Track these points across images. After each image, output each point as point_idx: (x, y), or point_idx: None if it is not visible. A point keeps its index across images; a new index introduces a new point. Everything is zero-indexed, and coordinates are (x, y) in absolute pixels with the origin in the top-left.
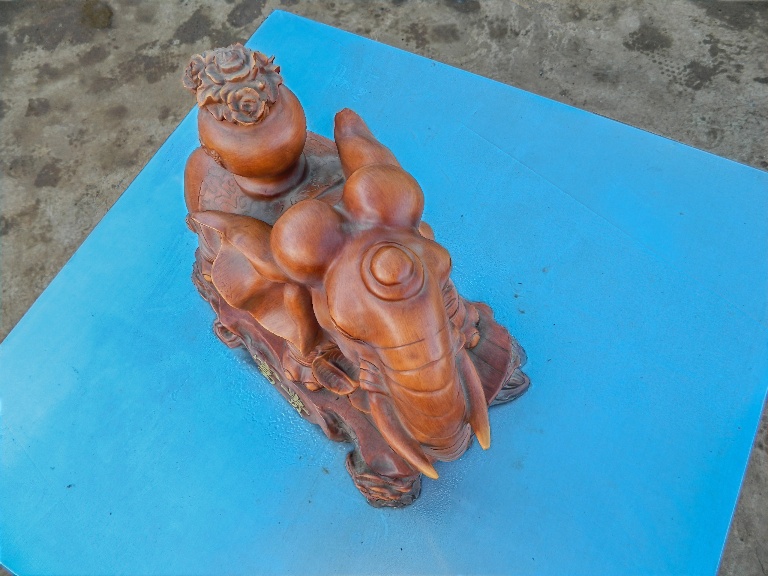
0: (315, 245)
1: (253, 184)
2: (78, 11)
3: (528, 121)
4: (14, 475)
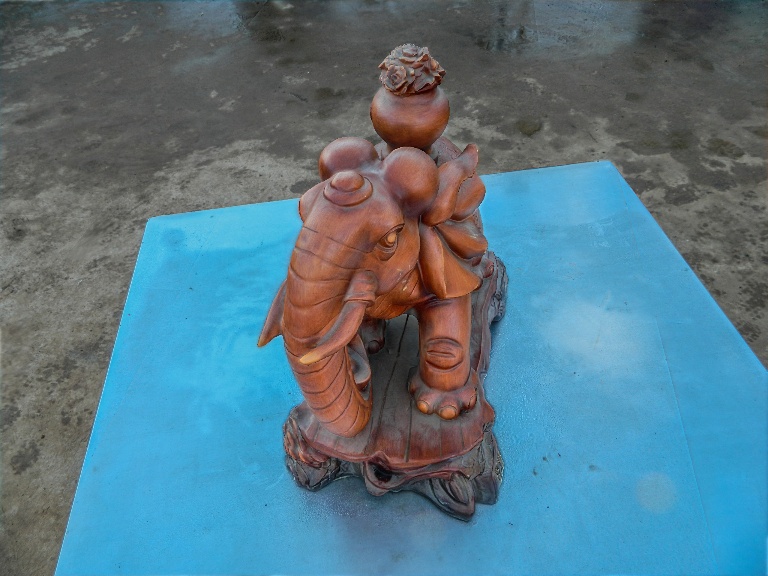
0: (337, 155)
1: (386, 150)
2: (521, 116)
3: (720, 365)
4: (182, 261)
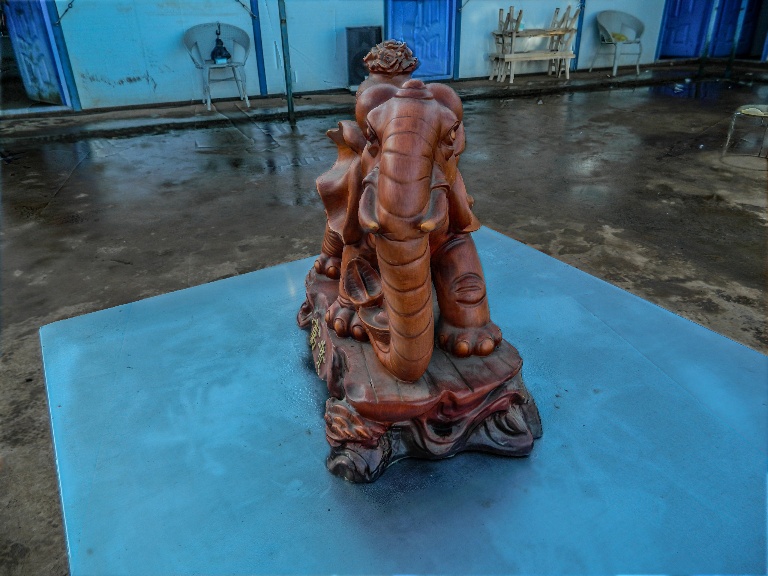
0: (380, 91)
1: None
2: None
3: (631, 310)
4: (104, 349)
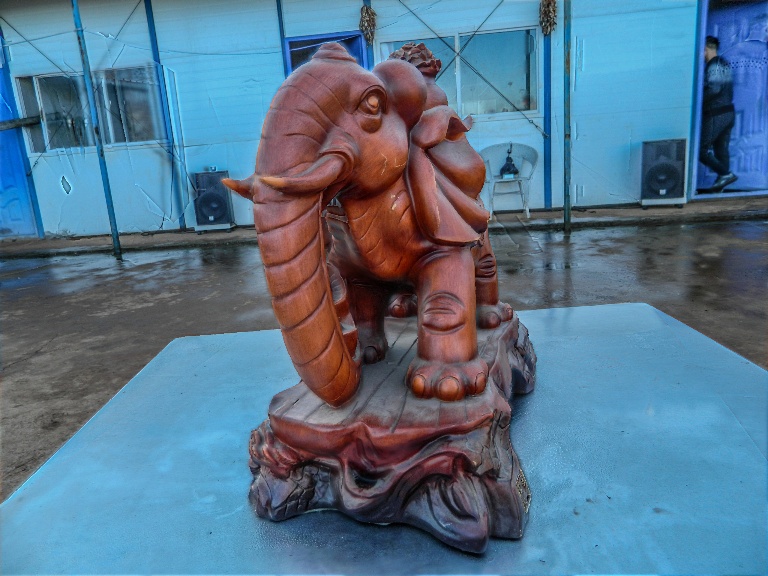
0: None
1: None
2: None
3: None
4: (194, 359)
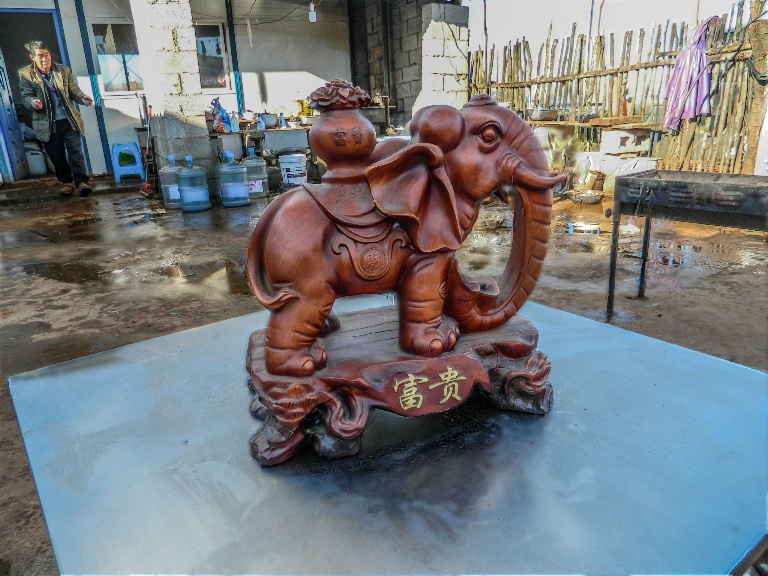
0: None
1: (360, 170)
2: None
3: None
4: None
